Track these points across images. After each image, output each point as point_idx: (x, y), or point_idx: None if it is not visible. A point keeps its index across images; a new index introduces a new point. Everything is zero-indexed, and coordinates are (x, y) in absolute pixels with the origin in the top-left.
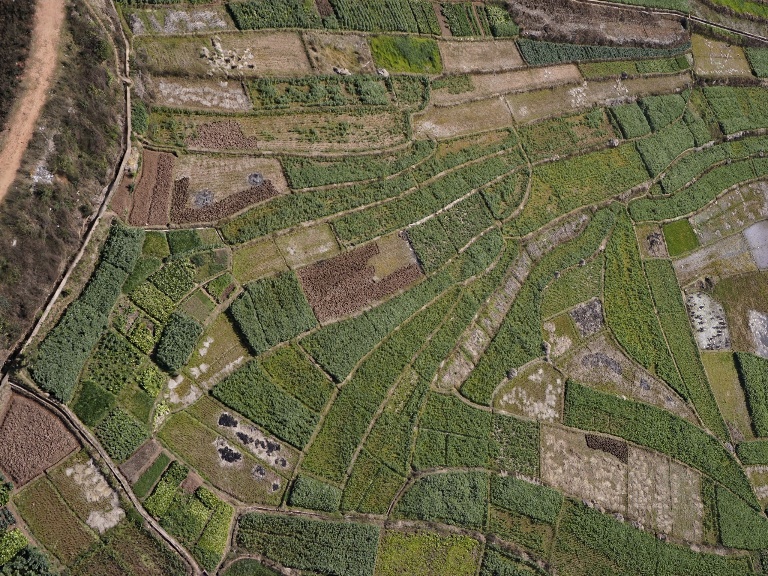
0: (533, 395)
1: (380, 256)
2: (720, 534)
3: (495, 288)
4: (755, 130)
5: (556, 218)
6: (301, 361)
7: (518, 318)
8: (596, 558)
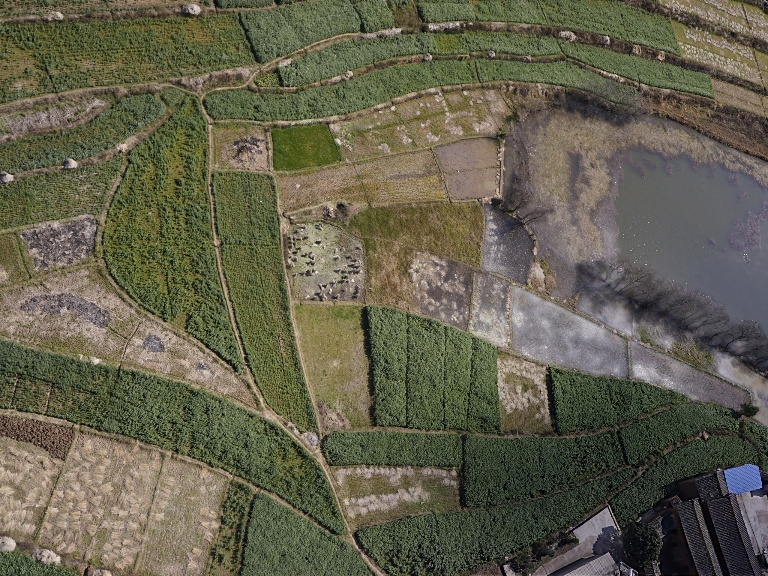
0: None
1: None
2: (241, 569)
3: None
4: (486, 23)
5: (29, 98)
6: None
7: None
8: None
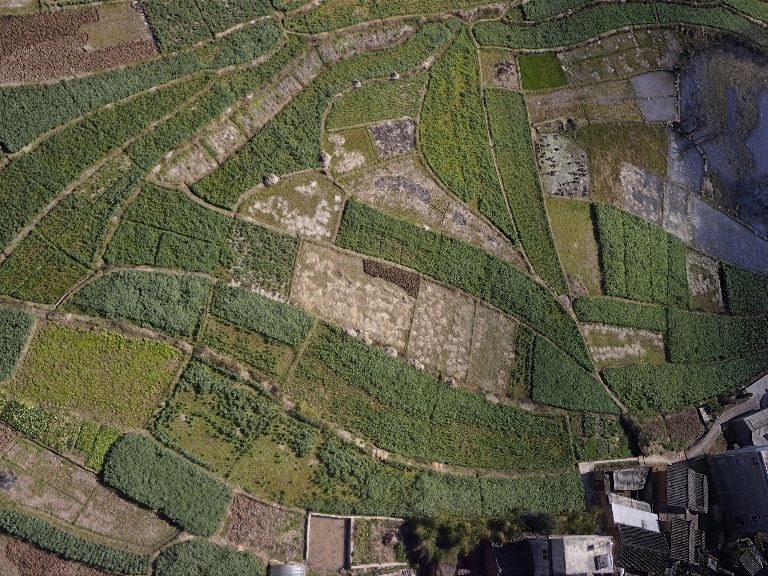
0: (298, 208)
1: (99, 24)
2: (532, 388)
3: (262, 84)
4: None
5: (365, 22)
6: None
7: (291, 122)
8: (351, 391)
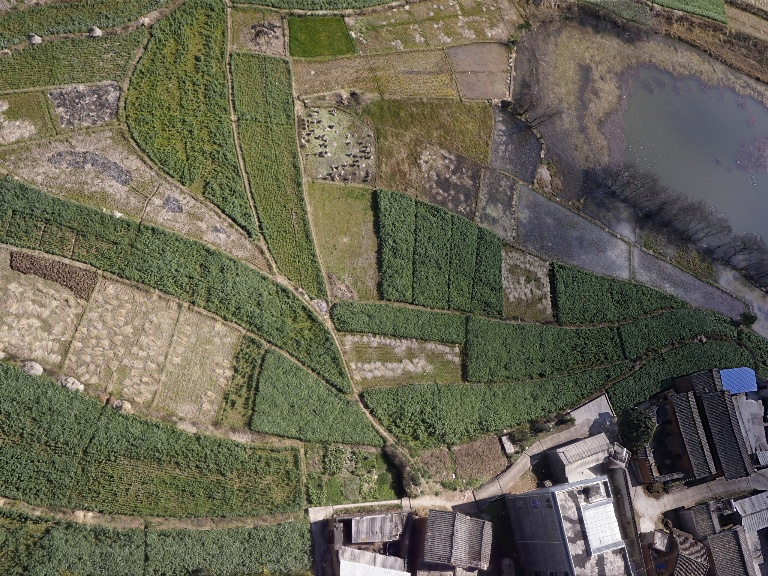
0: None
1: None
2: (252, 414)
3: None
4: None
5: None
6: None
7: None
8: None
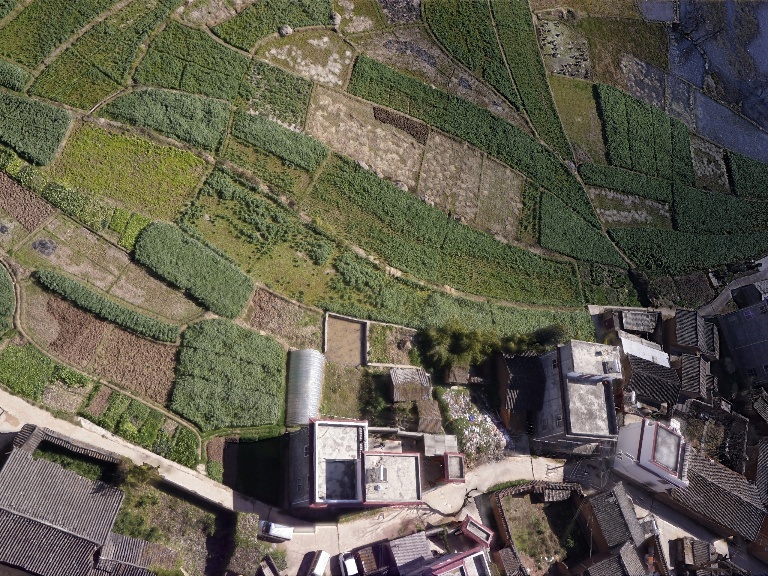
0: (311, 58)
1: None
2: (539, 236)
3: None
4: None
5: None
6: None
7: None
8: (364, 216)
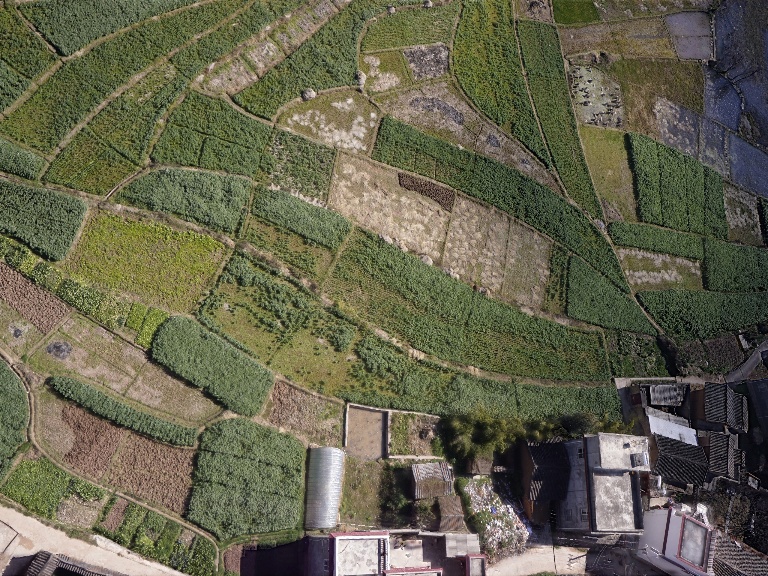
0: (335, 122)
1: None
2: (567, 305)
3: (300, 5)
4: None
5: None
6: (17, 26)
7: (327, 42)
8: (387, 294)
